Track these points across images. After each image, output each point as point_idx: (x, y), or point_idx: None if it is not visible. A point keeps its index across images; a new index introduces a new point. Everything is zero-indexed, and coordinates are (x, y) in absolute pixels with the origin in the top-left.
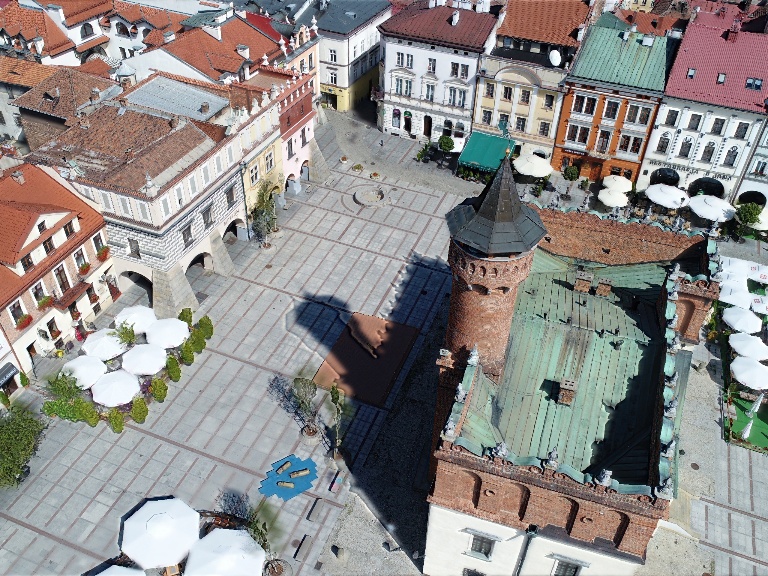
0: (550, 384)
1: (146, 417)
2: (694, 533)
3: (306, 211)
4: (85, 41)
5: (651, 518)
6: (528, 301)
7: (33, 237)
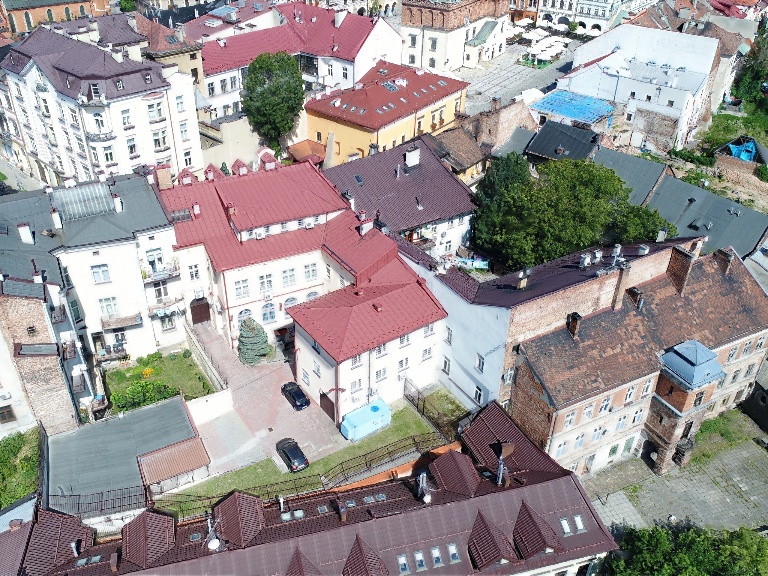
0: None
1: None
2: None
3: (392, 19)
4: None
5: (448, 12)
6: None
7: None
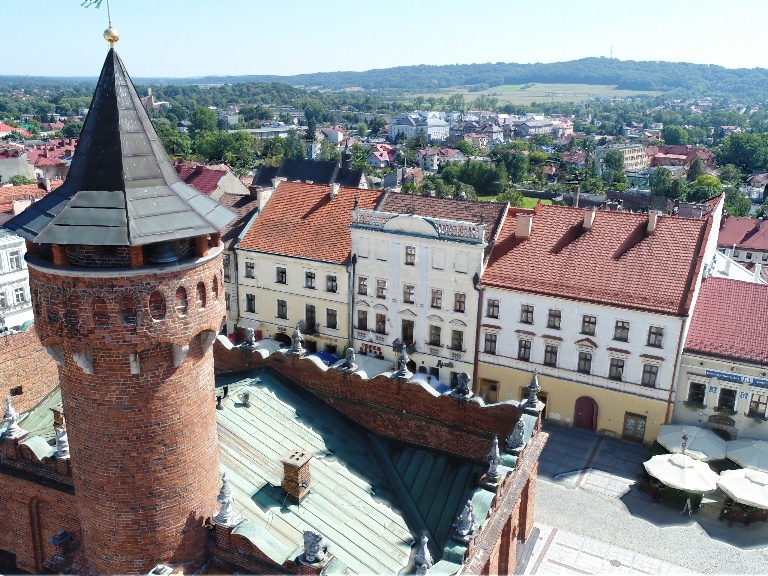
0: (263, 496)
1: None
2: None
3: None
4: None
5: None
6: None
7: None
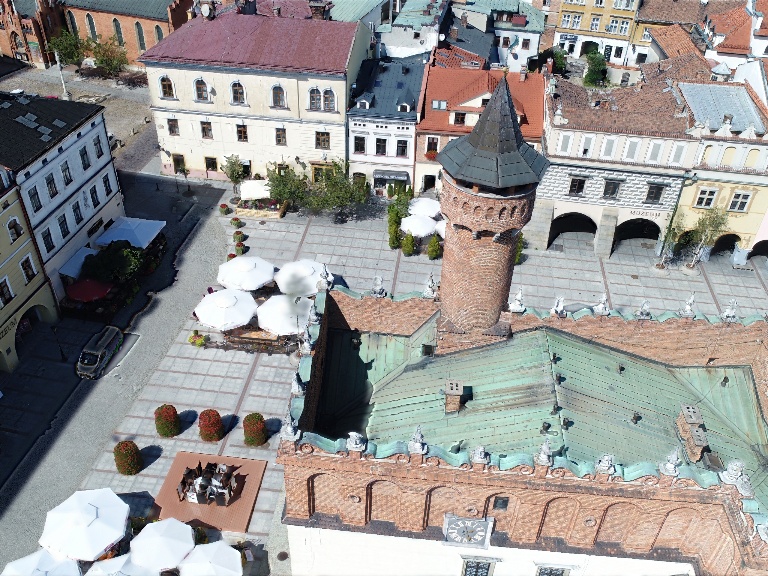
0: (468, 392)
1: (412, 256)
2: None
3: (749, 282)
4: (767, 56)
5: None
6: (593, 360)
7: (475, 104)
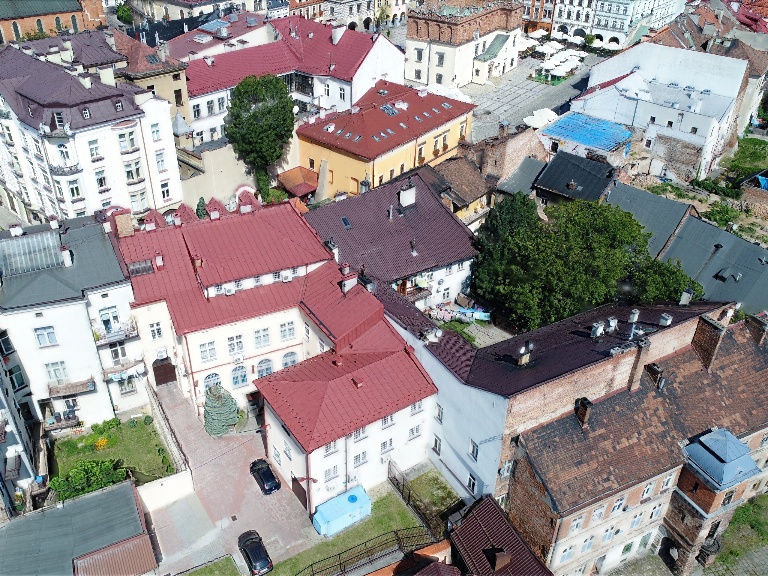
0: None
1: None
2: (497, 85)
3: (400, 29)
4: None
5: (456, 26)
6: None
7: None
